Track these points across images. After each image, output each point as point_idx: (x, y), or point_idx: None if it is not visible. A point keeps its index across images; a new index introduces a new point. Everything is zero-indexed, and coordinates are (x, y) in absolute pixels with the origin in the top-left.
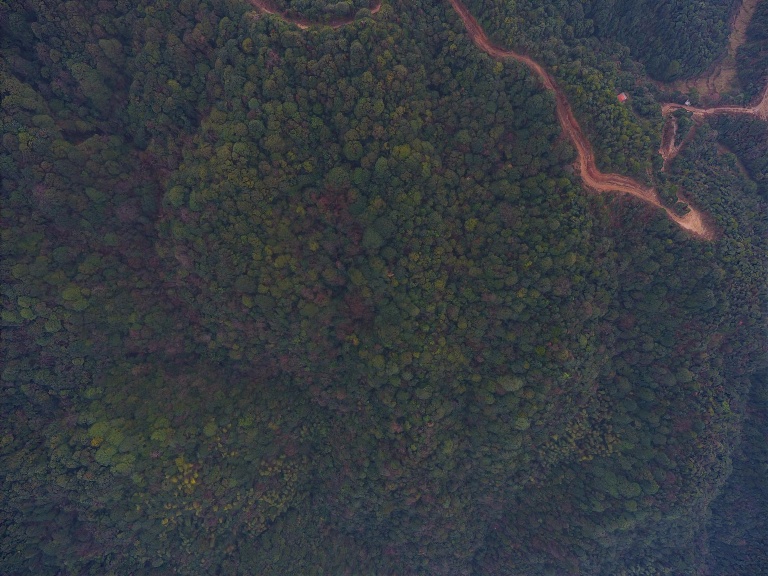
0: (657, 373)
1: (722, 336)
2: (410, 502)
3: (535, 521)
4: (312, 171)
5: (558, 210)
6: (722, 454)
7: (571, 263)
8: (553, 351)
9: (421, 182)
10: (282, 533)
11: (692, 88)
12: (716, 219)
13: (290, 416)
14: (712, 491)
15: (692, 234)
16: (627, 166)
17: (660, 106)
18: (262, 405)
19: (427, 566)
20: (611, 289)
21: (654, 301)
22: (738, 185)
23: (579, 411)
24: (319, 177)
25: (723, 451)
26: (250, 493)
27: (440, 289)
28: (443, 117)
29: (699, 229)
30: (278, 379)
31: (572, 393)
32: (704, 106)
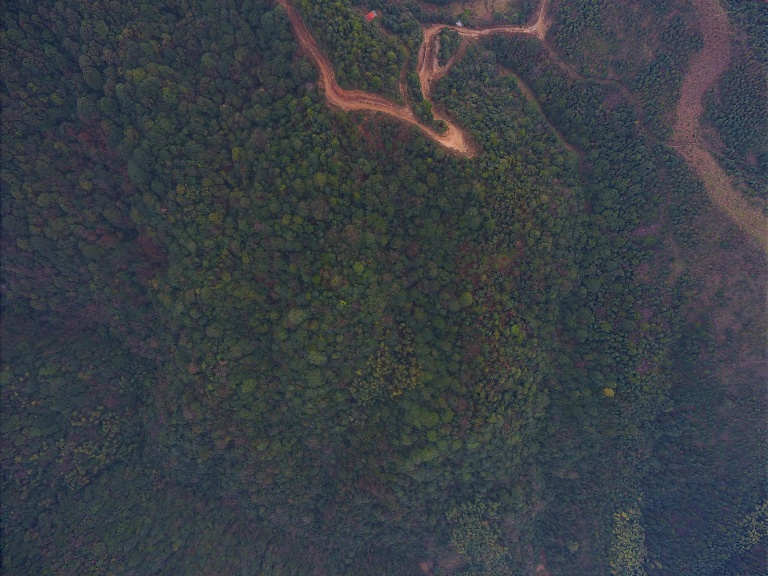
0: (445, 299)
1: (509, 260)
2: (221, 445)
3: (359, 461)
4: (63, 104)
5: (299, 129)
6: (524, 381)
7: (319, 183)
8: (328, 279)
9: (166, 108)
10: (106, 485)
11: (467, 10)
12: (475, 135)
13: (103, 366)
14: (521, 420)
15: (452, 152)
16: (366, 81)
17: (419, 25)
18: (70, 355)
19: (265, 514)
20: (387, 215)
21: (430, 225)
22: (515, 105)
23: (379, 344)
24: (73, 111)
25: (524, 377)
26: (60, 443)
27: (216, 223)
28: (183, 41)
29: (460, 147)
30: (96, 331)
31: (363, 324)
32: (478, 27)
